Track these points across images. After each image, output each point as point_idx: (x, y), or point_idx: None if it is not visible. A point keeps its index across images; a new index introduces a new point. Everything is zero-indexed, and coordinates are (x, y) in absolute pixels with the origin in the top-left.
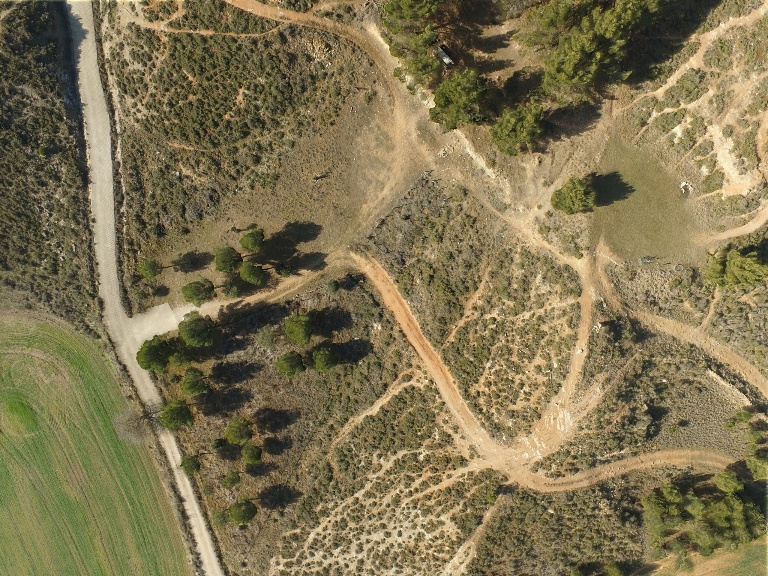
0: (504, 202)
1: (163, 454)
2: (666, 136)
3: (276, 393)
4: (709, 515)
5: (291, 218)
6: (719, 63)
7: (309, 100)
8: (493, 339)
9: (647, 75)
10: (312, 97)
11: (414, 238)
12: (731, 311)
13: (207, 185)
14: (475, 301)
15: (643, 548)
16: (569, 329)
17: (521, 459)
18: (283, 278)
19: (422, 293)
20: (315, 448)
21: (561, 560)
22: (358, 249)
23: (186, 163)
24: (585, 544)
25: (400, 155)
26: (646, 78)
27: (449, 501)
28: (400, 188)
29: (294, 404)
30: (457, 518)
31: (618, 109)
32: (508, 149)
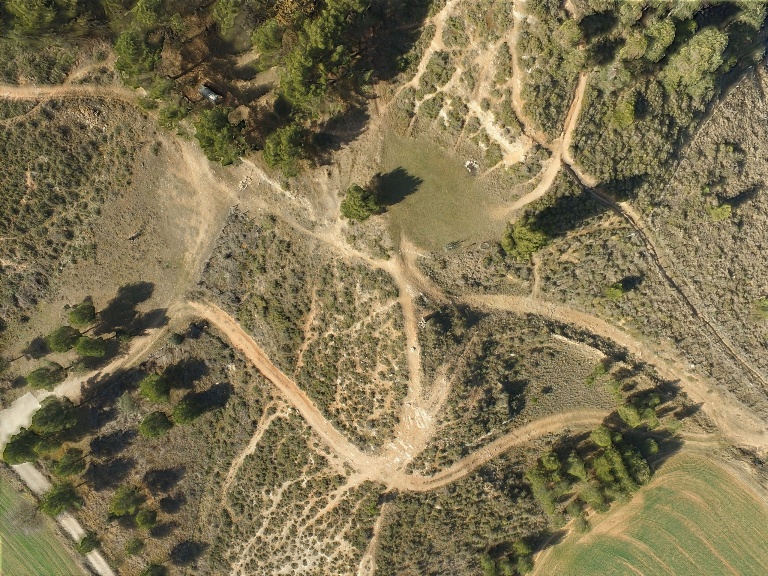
0: (310, 220)
1: (70, 538)
2: (436, 121)
3: (158, 454)
4: (597, 472)
5: (121, 282)
6: (457, 41)
7: (99, 165)
8: (335, 355)
9: (397, 68)
10: (101, 161)
11: (241, 274)
12: (556, 273)
13: (31, 270)
14: (311, 322)
15: (546, 518)
16: (395, 331)
17: (393, 465)
18: (132, 341)
19: (262, 326)
20: (209, 498)
21: (465, 550)
22: (194, 296)
23: (2, 254)
24: (484, 529)
25: (203, 197)
26: (397, 70)
27: (339, 521)
28: (214, 229)
29: (178, 460)
30: (350, 536)
31: (383, 106)
32: (288, 171)
